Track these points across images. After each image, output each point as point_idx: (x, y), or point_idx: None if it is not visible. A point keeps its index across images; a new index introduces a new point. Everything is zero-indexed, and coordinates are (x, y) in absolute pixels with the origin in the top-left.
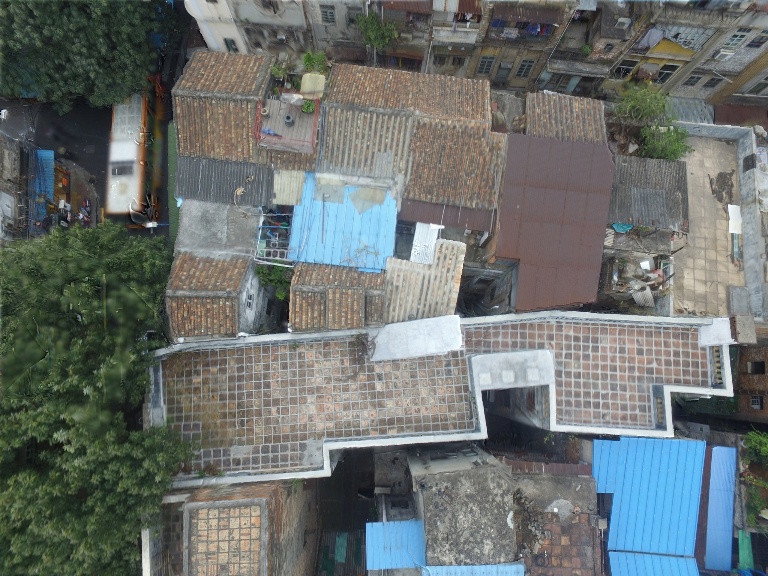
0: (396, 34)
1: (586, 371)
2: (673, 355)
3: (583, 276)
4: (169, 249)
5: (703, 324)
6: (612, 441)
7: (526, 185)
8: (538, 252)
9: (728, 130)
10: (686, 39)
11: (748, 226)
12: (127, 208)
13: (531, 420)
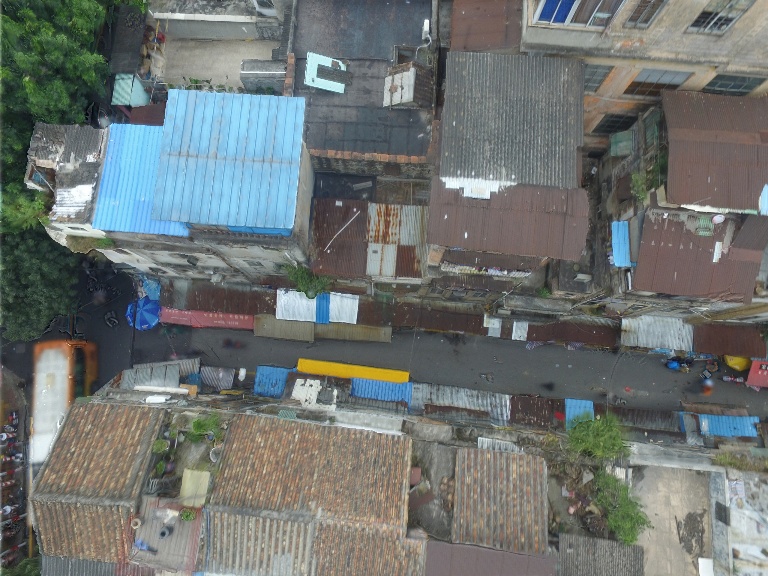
0: (332, 280)
1: None
2: None
3: None
4: None
5: None
6: None
7: None
8: None
9: None
10: None
11: None
12: (54, 428)
13: None
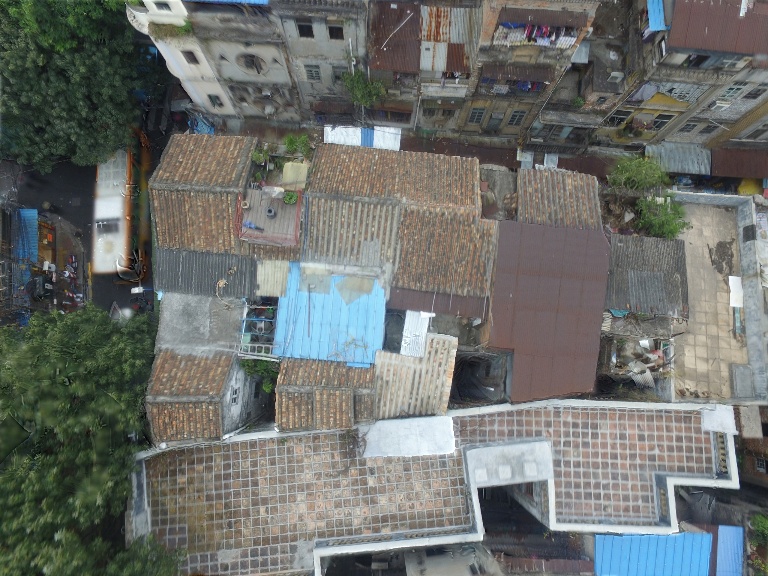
0: (383, 91)
1: (586, 460)
2: (676, 440)
3: (580, 365)
4: (153, 328)
5: (706, 408)
6: (614, 536)
7: (519, 273)
8: (533, 342)
9: (727, 198)
10: (681, 93)
11: (750, 300)
12: (114, 265)
13: (530, 512)
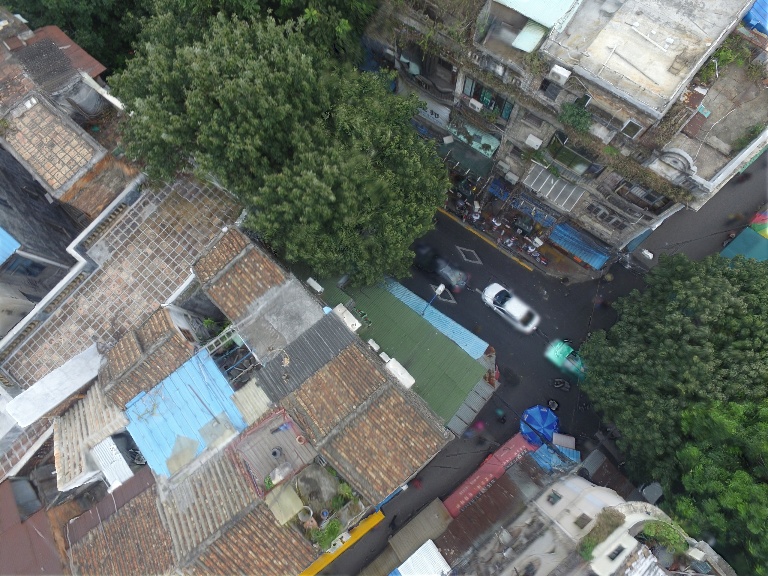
0: None
1: None
2: None
3: None
4: (361, 281)
5: None
6: None
7: None
8: (8, 544)
9: None
10: None
11: None
12: (506, 287)
13: None
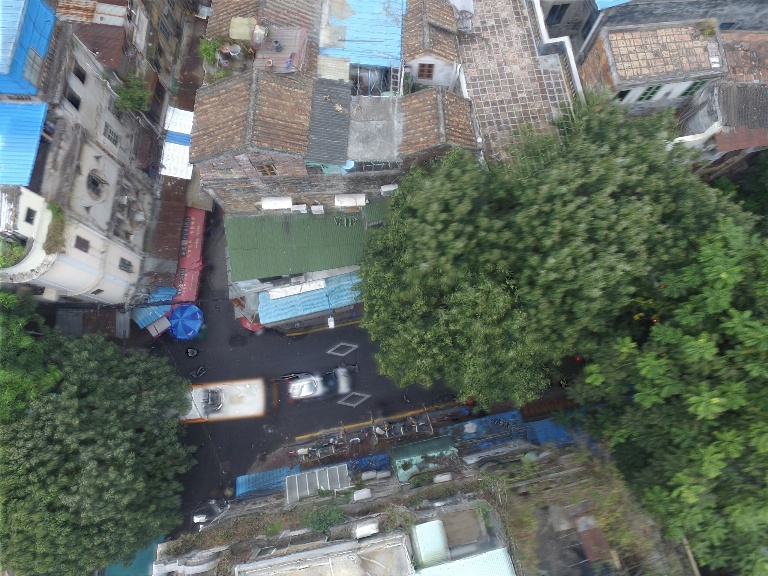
0: None
1: None
2: None
3: None
4: None
5: None
6: None
7: None
8: None
9: None
10: None
11: None
12: (299, 397)
13: None
